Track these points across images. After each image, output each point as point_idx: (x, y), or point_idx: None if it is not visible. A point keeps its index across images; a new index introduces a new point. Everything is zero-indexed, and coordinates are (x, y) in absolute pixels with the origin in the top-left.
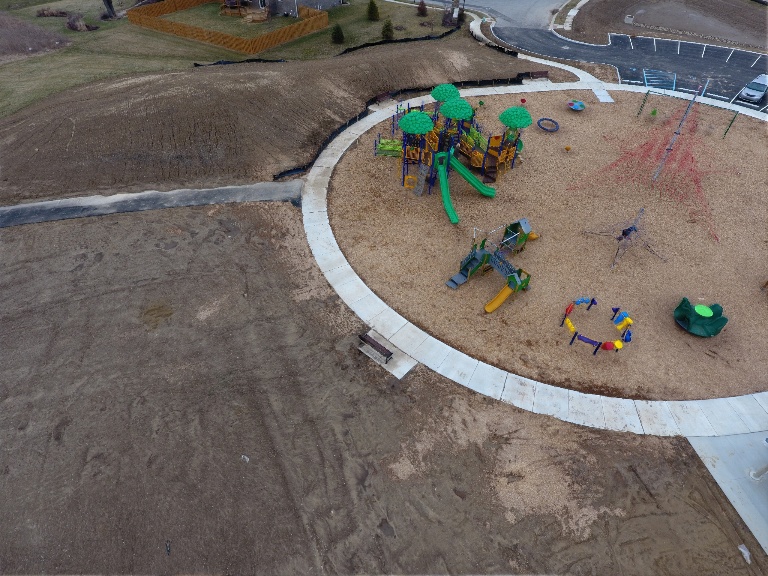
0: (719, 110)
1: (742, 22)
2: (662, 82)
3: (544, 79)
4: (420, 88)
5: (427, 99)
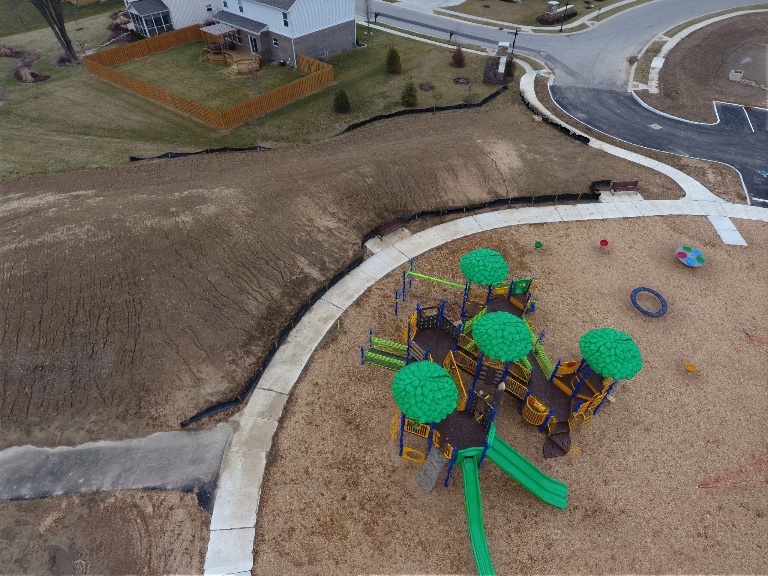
0: None
1: None
2: None
3: (631, 191)
4: (446, 207)
5: (455, 229)
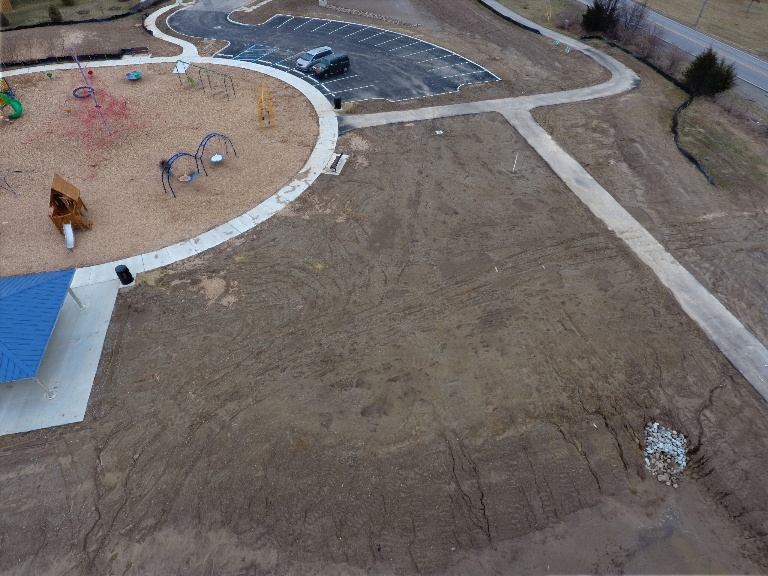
0: (265, 78)
1: (424, 3)
2: (252, 55)
3: (147, 54)
4: None
5: (10, 73)
